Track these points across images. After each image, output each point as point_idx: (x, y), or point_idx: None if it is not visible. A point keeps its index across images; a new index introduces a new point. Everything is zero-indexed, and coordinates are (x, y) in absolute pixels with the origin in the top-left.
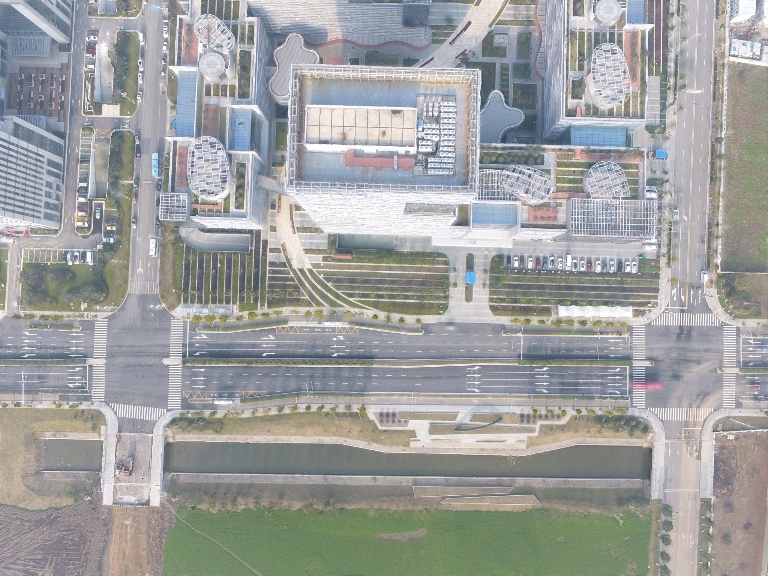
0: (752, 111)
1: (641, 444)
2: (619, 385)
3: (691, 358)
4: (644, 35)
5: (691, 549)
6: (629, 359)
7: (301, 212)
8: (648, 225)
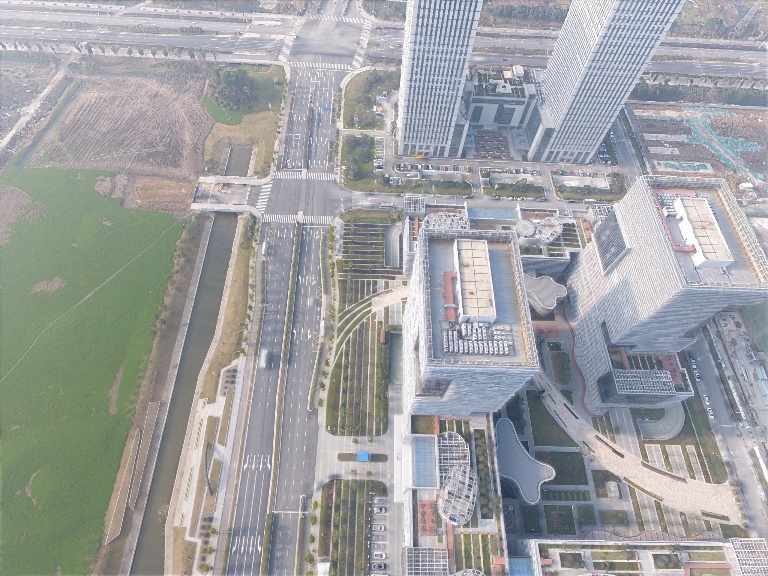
0: None
1: None
2: None
3: None
4: None
5: None
6: None
7: None
8: None
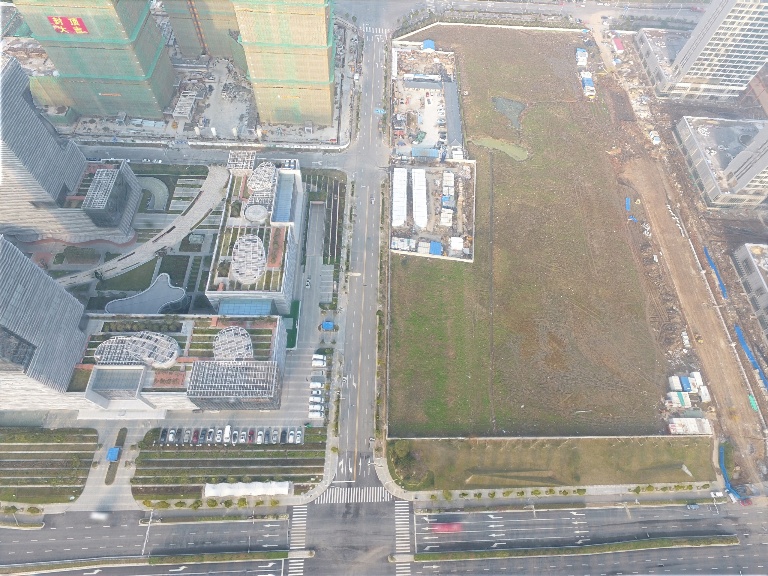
0: (415, 290)
1: None
2: None
3: (358, 544)
4: None
5: None
6: (285, 549)
7: None
8: (267, 384)
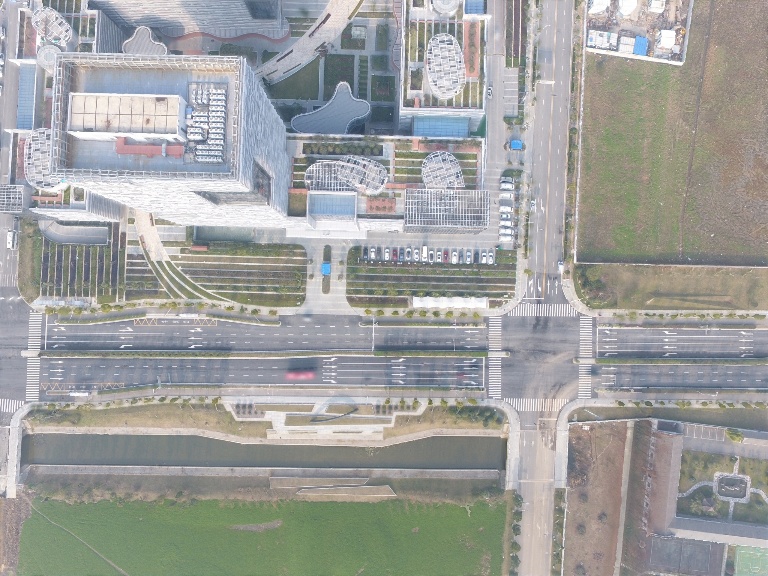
0: (610, 102)
1: (498, 435)
2: (475, 376)
3: (547, 349)
4: (483, 26)
5: (546, 539)
6: (485, 350)
7: None
8: (482, 215)
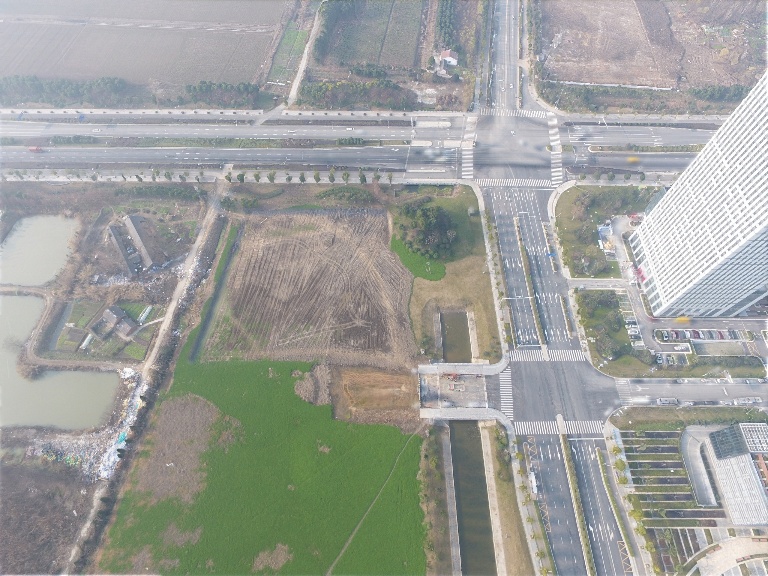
0: None
1: None
2: None
3: None
4: None
5: None
6: None
7: (764, 569)
8: None
